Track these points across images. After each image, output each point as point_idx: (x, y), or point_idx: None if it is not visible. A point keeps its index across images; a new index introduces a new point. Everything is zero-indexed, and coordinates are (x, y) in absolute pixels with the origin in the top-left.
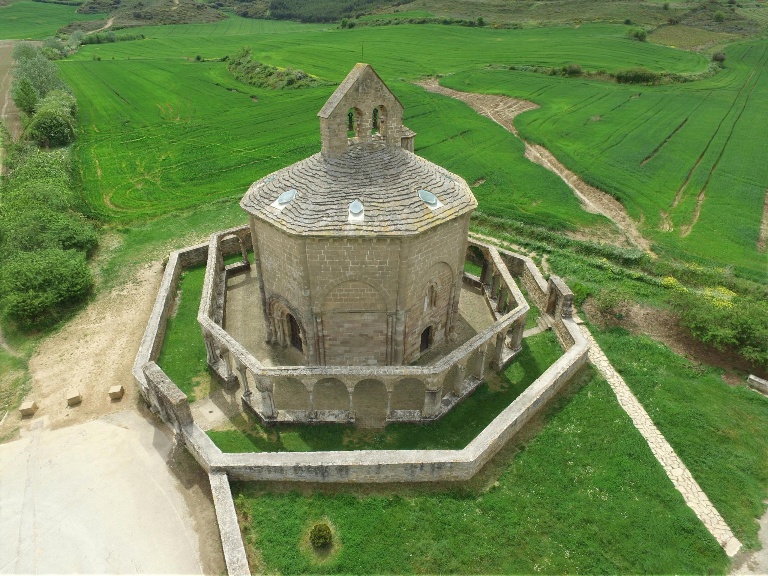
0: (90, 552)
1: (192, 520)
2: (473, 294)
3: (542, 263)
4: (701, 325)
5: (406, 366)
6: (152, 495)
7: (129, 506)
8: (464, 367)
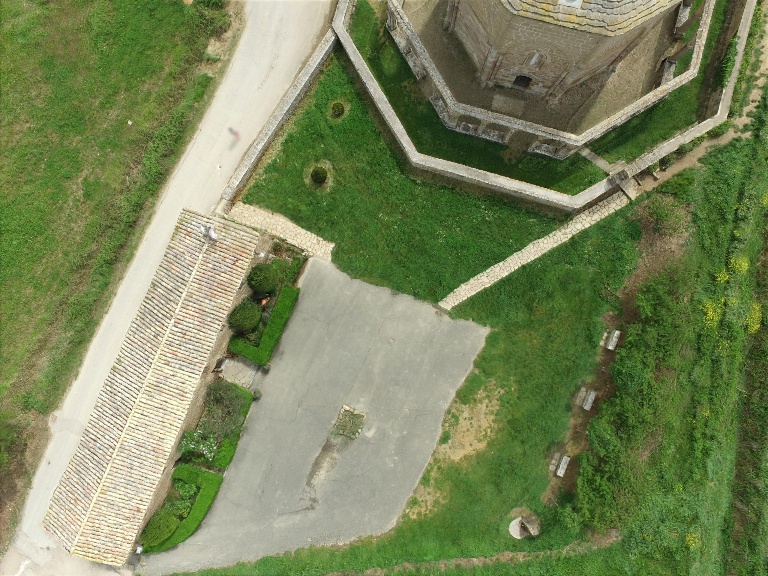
0: (277, 9)
1: (315, 41)
2: (639, 89)
3: (728, 135)
4: (651, 289)
5: (445, 86)
6: (315, 8)
7: (304, 3)
8: (484, 124)
